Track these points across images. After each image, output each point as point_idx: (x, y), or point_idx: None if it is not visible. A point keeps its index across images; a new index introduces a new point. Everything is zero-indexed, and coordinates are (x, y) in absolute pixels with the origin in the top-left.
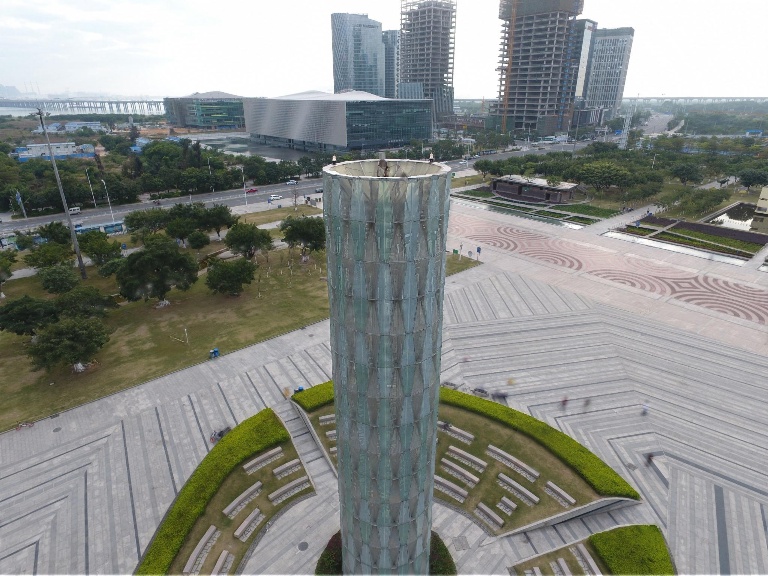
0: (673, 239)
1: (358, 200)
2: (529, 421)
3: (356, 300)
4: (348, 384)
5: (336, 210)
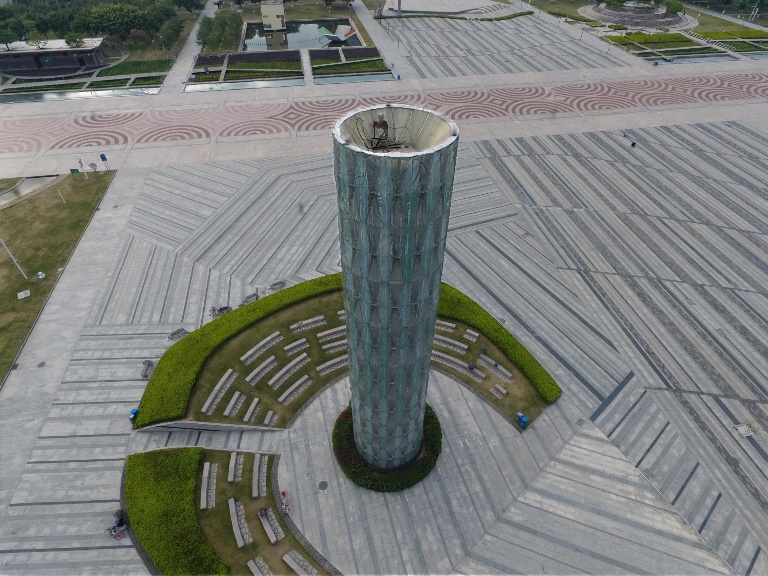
0: (241, 76)
1: (433, 170)
2: (335, 278)
3: (424, 254)
4: (409, 323)
5: (407, 188)
